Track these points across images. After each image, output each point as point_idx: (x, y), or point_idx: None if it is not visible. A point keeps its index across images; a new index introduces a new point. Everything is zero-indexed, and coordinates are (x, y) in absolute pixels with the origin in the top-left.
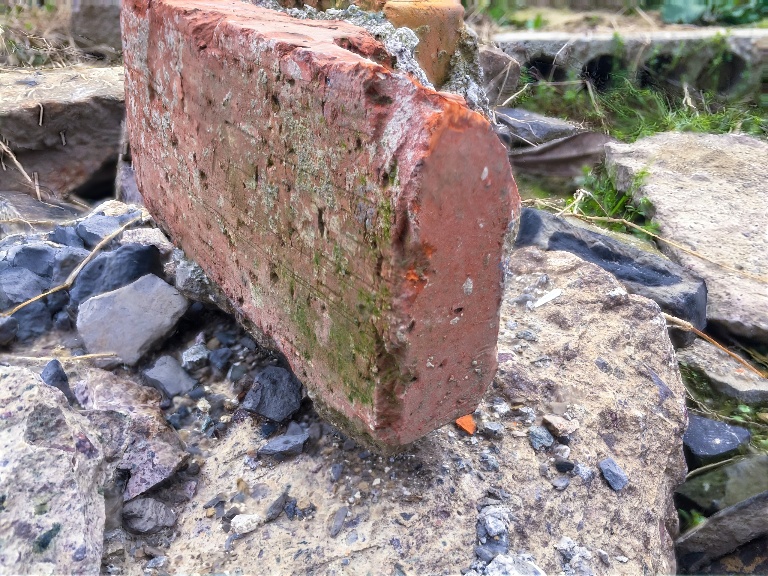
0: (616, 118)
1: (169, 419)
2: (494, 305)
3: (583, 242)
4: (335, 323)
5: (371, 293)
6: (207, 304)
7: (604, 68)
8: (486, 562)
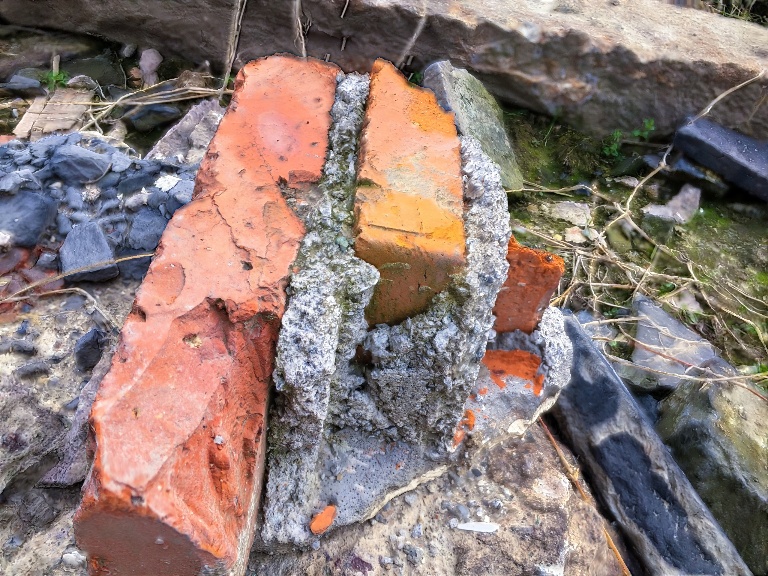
0: None
1: None
2: None
3: (648, 459)
4: None
5: None
6: None
7: None
8: None
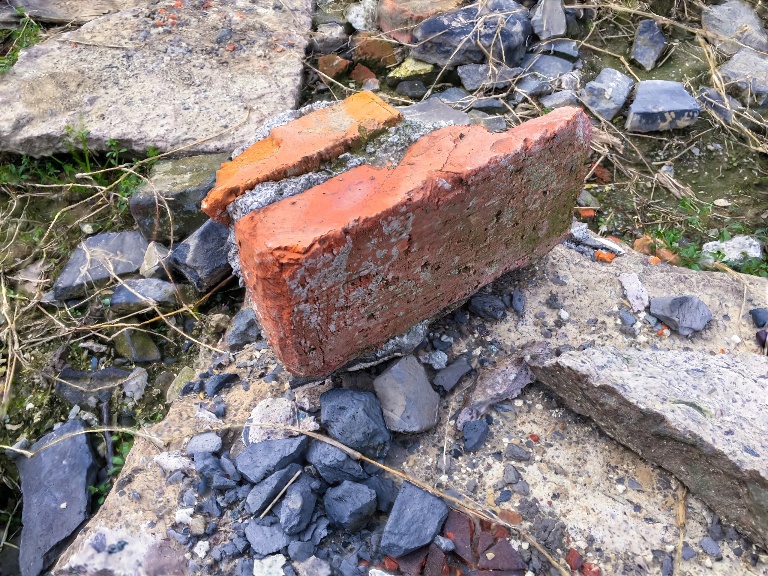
0: None
1: None
2: None
3: None
4: None
5: None
6: None
7: None
8: (565, 240)
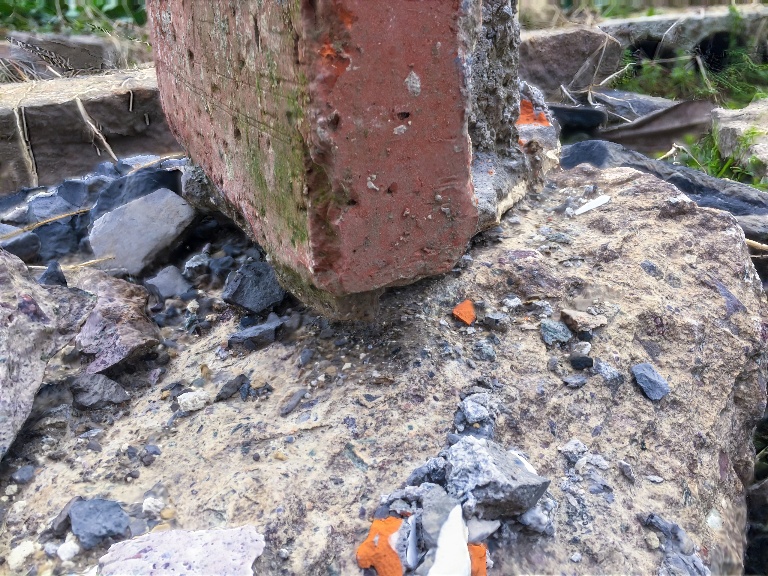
0: (732, 95)
1: (154, 317)
2: (456, 120)
3: (658, 174)
4: (277, 154)
5: (294, 90)
6: (218, 218)
7: (719, 45)
8: None
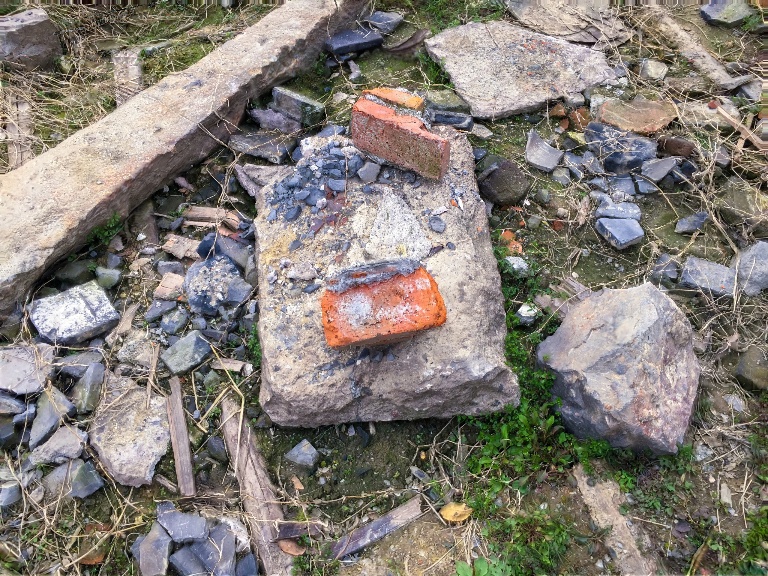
0: (417, 2)
1: None
2: None
3: (442, 115)
4: None
5: (437, 163)
6: None
7: None
8: None
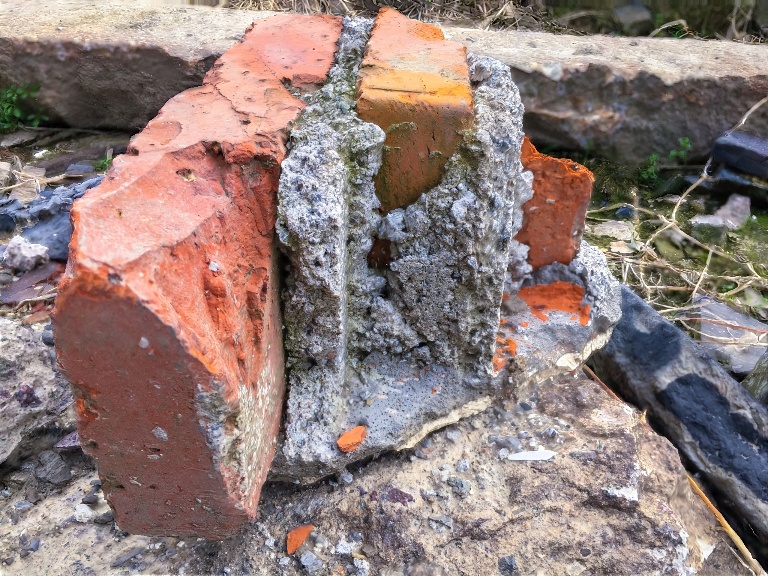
0: None
1: None
2: (207, 460)
3: (726, 401)
4: None
5: None
6: None
7: None
8: None
